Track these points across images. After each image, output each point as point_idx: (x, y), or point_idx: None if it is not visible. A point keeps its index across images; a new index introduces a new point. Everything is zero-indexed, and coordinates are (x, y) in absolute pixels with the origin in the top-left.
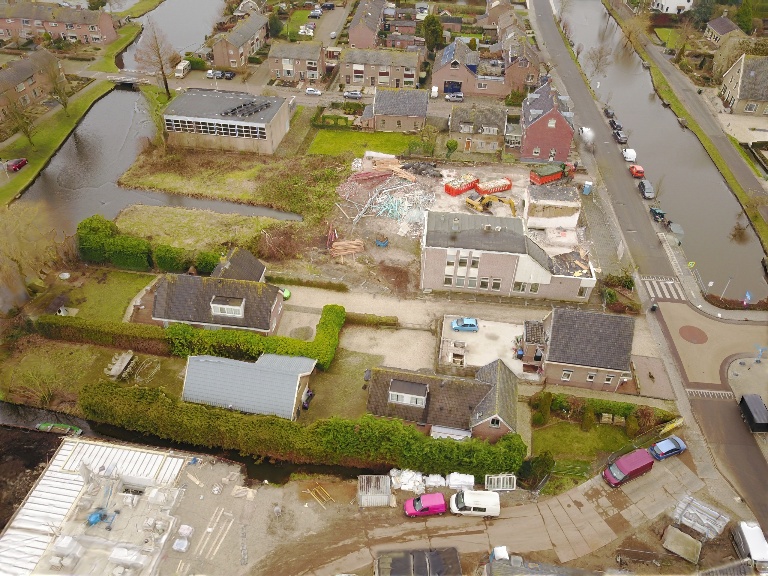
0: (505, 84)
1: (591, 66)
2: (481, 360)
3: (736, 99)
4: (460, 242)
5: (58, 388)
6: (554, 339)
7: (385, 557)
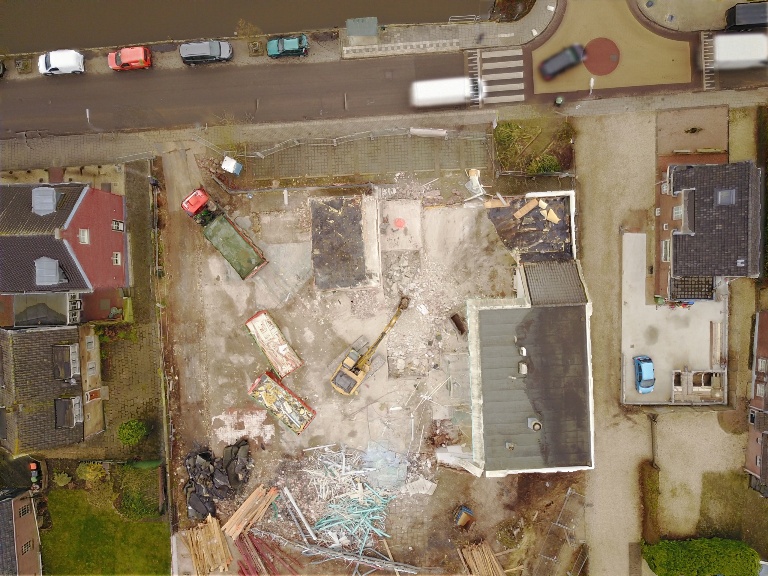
0: None
1: None
2: (699, 350)
3: None
4: (569, 412)
5: None
6: (756, 270)
7: None
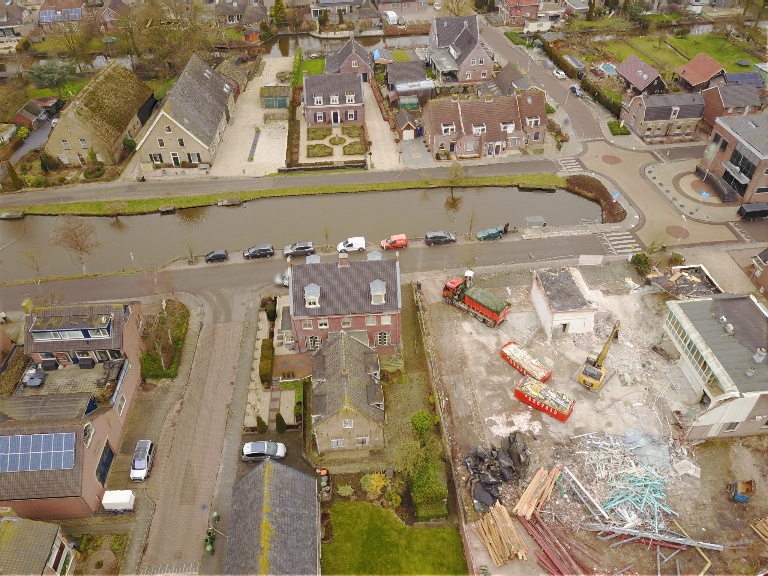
0: (132, 365)
1: (73, 254)
2: None
3: (203, 151)
4: None
5: None
6: None
7: None
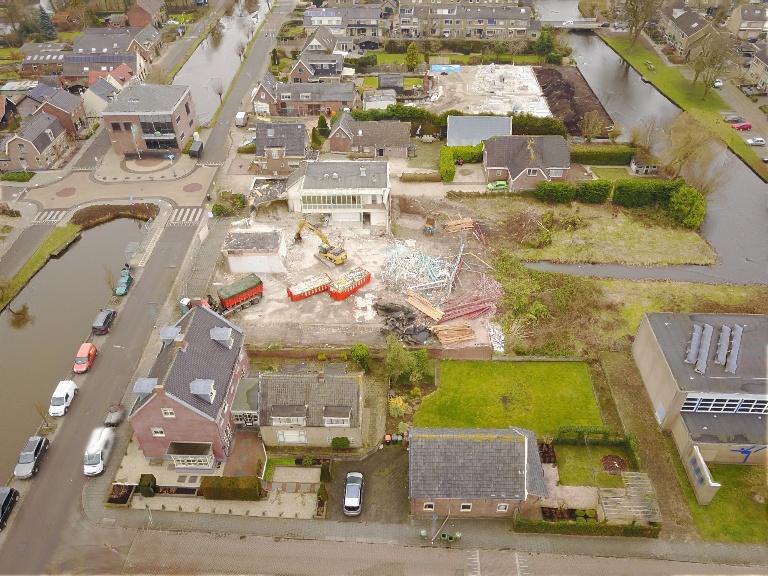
0: None
1: None
2: None
3: None
4: None
5: (589, 146)
6: None
7: (392, 99)
